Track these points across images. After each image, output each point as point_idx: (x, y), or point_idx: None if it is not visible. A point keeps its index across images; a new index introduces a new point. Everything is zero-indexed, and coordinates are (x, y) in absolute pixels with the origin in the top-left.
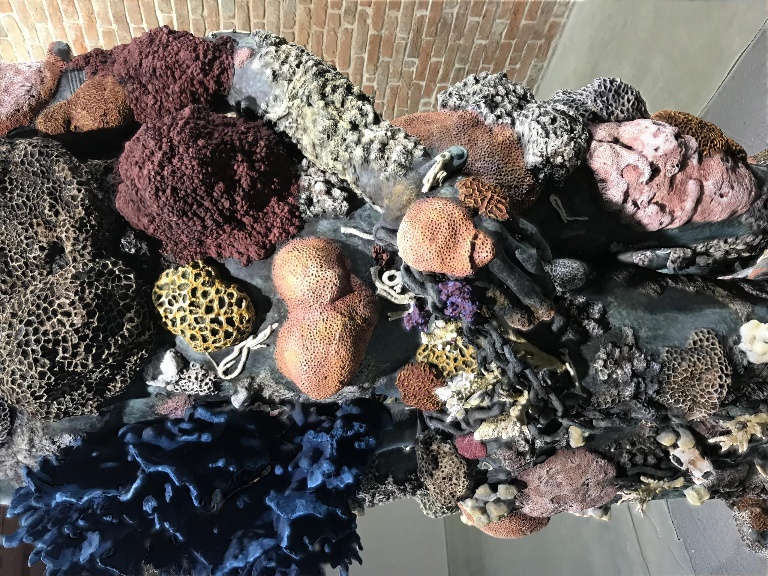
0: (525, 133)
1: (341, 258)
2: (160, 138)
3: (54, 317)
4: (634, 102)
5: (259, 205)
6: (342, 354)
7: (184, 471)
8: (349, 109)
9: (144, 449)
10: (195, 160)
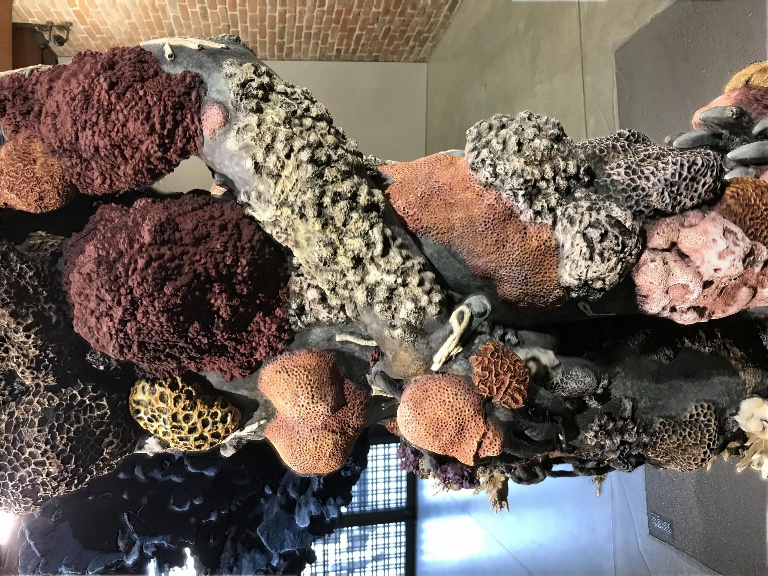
0: (566, 246)
1: (335, 368)
2: (117, 287)
3: (28, 465)
4: (710, 185)
5: (242, 325)
6: (332, 464)
7: (179, 526)
8: (352, 231)
9: (138, 486)
10: (163, 314)
